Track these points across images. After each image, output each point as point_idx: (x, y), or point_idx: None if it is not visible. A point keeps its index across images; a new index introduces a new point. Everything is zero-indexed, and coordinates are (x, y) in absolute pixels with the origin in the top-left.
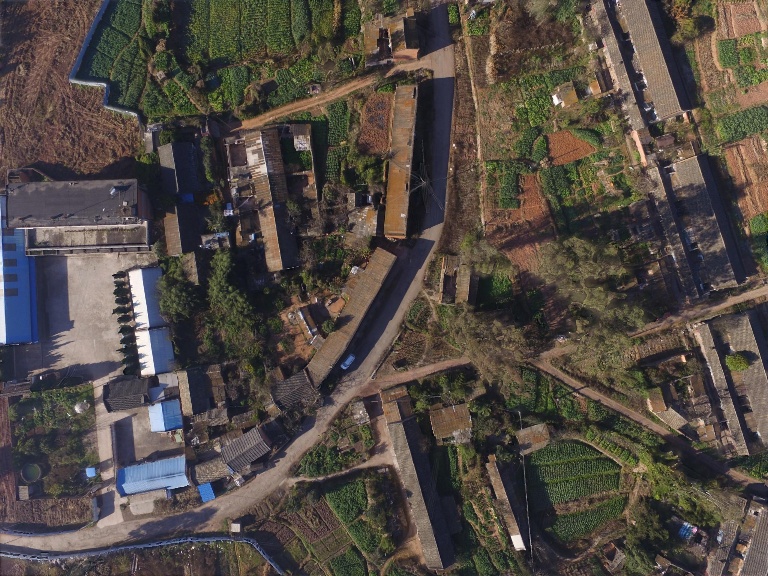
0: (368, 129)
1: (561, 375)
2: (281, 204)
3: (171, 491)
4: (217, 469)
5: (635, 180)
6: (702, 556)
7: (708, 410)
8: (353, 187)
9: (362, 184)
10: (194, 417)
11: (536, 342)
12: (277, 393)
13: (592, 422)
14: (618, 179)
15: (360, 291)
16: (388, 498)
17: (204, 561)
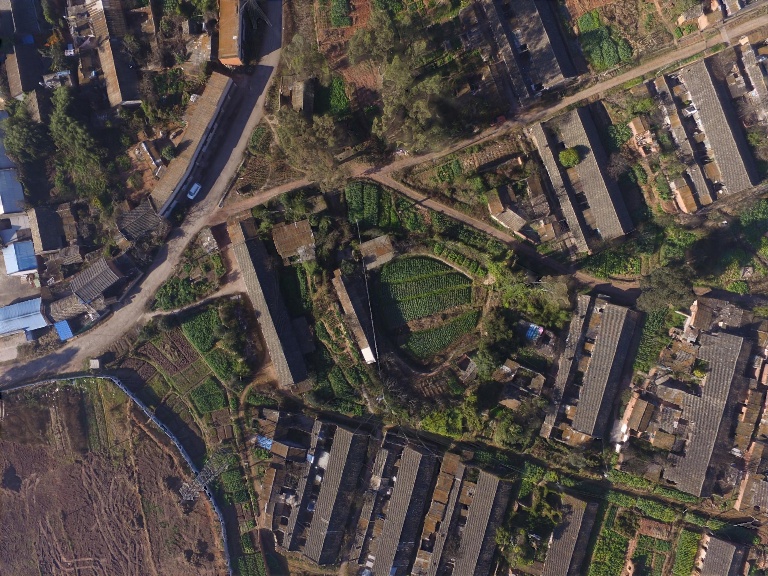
0: None
1: (403, 188)
2: (119, 39)
3: (33, 335)
4: (71, 304)
5: None
6: (552, 358)
7: (546, 209)
8: (190, 19)
9: (199, 15)
10: (47, 256)
11: (376, 157)
12: (123, 222)
13: None
14: None
15: (198, 116)
16: (241, 323)
17: (67, 401)
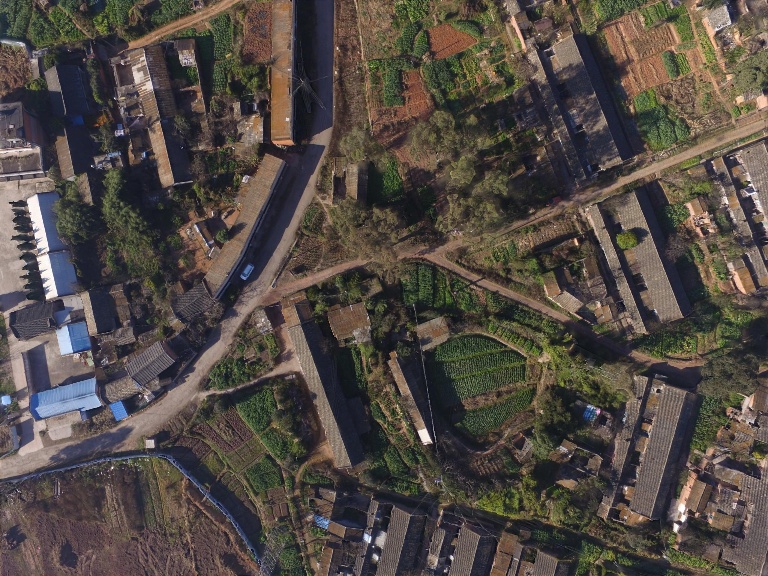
0: (251, 39)
1: (457, 269)
2: (169, 119)
3: (87, 414)
4: (126, 386)
5: (516, 66)
6: (608, 438)
7: (603, 291)
8: (240, 98)
9: (249, 94)
10: (101, 338)
11: (430, 238)
12: (177, 306)
13: (492, 313)
14: (501, 68)
15: (251, 198)
16: (296, 403)
17: (123, 479)
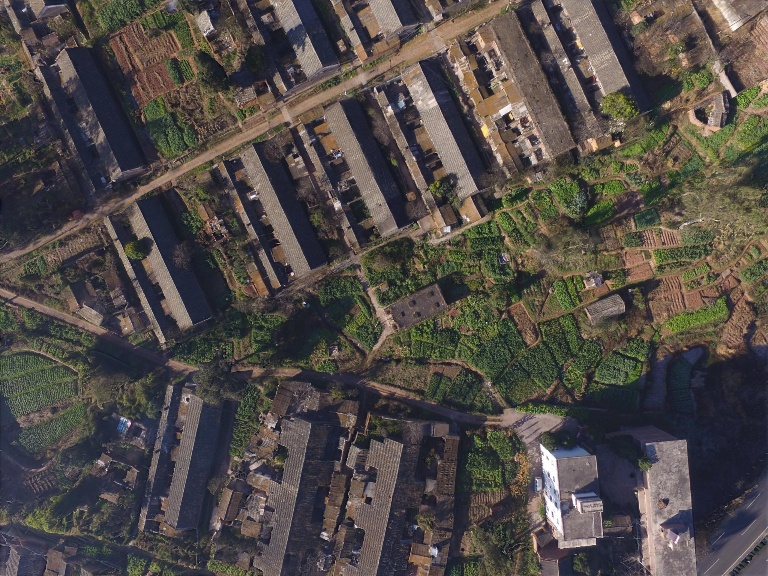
0: None
1: None
2: None
3: None
4: None
5: (26, 83)
6: (146, 449)
7: (123, 302)
8: None
9: None
10: None
11: None
12: None
13: (29, 330)
14: (19, 85)
15: None
16: None
17: None
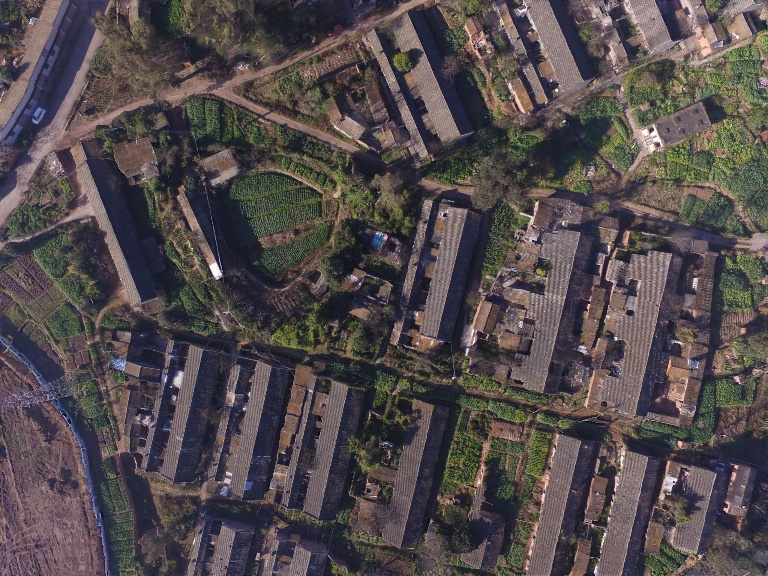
0: None
1: (245, 103)
2: None
3: None
4: None
5: None
6: (399, 265)
7: (385, 115)
8: None
9: None
10: None
11: (218, 73)
12: None
13: None
14: None
15: (36, 38)
16: (91, 246)
17: None
